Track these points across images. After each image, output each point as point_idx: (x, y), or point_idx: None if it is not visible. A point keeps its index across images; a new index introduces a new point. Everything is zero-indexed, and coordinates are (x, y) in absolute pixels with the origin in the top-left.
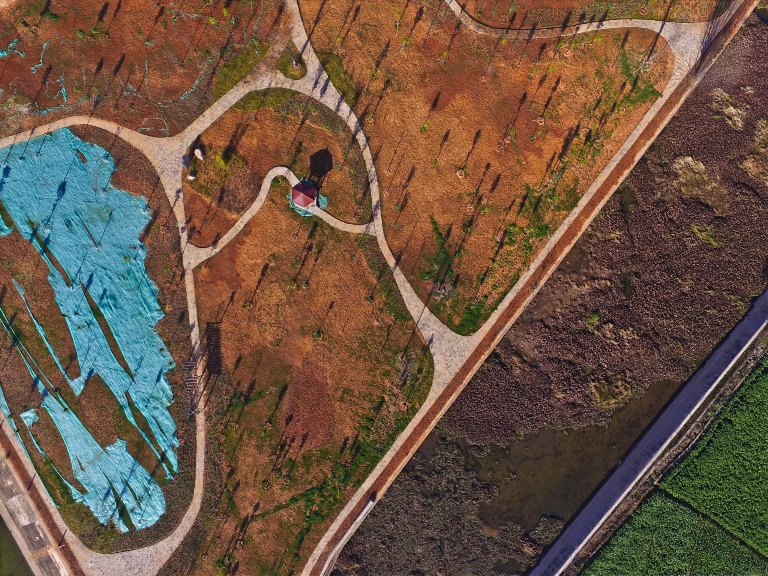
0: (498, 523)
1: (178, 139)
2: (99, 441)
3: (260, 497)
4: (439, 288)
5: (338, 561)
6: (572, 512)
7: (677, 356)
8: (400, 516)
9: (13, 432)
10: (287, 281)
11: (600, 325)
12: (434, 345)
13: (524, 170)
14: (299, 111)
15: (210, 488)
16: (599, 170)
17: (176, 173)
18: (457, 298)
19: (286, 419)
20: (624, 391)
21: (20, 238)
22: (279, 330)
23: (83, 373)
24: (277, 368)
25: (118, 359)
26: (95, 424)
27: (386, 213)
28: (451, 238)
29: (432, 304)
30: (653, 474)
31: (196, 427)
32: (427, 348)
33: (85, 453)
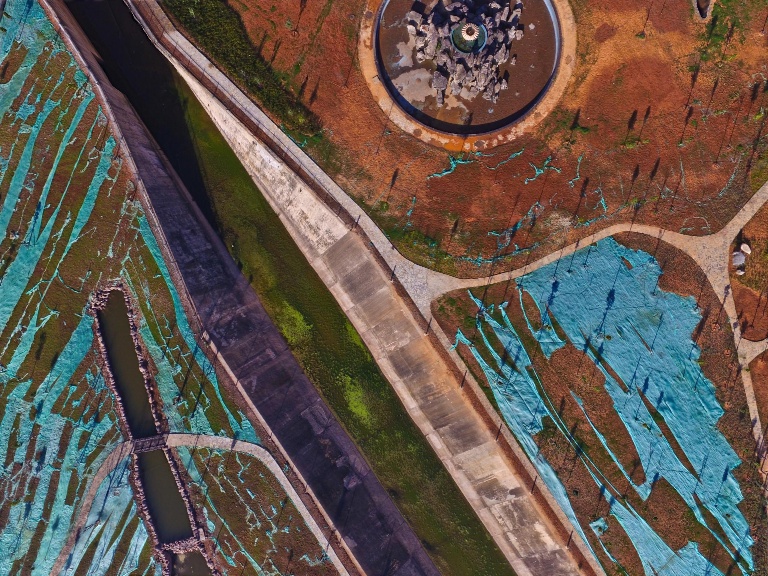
0: None
1: (721, 236)
2: (670, 545)
3: None
4: None
5: None
6: None
7: None
8: None
9: (583, 542)
10: None
11: None
12: None
13: None
14: None
15: None
16: None
17: (723, 270)
18: None
19: None
20: None
21: (574, 350)
22: None
23: (648, 478)
24: None
25: (682, 461)
26: (665, 528)
27: None
28: None
29: None
30: None
31: (767, 523)
32: None
33: (657, 558)
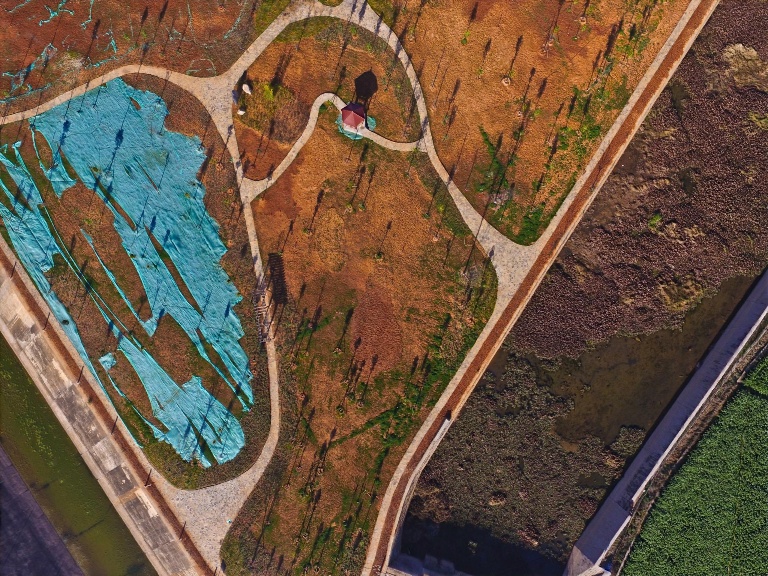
0: (576, 437)
1: (225, 77)
2: (175, 379)
3: (336, 423)
4: (495, 199)
5: (417, 486)
6: (652, 420)
7: (747, 250)
8: (475, 437)
9: (93, 377)
10: (343, 205)
11: (663, 225)
12: (495, 257)
13: (570, 72)
14: (340, 37)
15: (286, 417)
16: (647, 64)
17: (226, 110)
18: (514, 208)
19: (355, 343)
20: (695, 291)
21: (84, 189)
22: (340, 255)
23: (154, 314)
24: (341, 293)
25: (186, 297)
26: (170, 363)
27: (435, 128)
28: (503, 147)
29: (490, 216)
30: (735, 372)
31: (267, 358)
32: (489, 261)
33: (163, 392)
